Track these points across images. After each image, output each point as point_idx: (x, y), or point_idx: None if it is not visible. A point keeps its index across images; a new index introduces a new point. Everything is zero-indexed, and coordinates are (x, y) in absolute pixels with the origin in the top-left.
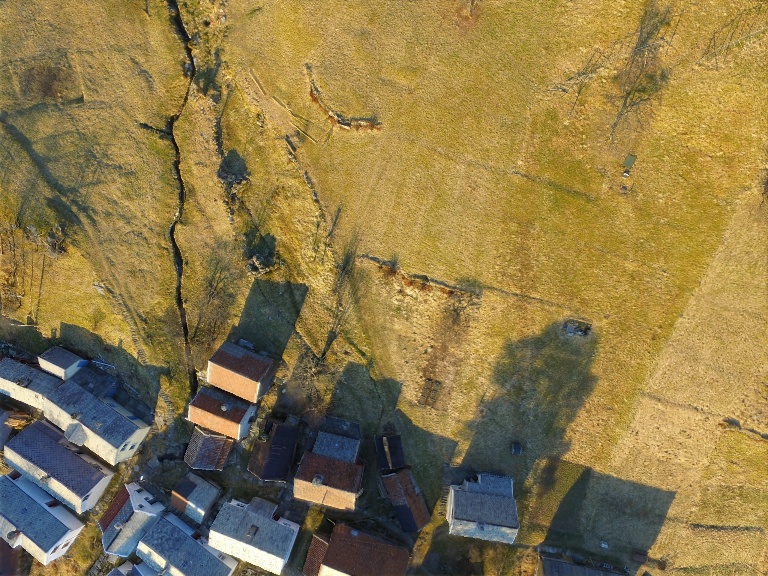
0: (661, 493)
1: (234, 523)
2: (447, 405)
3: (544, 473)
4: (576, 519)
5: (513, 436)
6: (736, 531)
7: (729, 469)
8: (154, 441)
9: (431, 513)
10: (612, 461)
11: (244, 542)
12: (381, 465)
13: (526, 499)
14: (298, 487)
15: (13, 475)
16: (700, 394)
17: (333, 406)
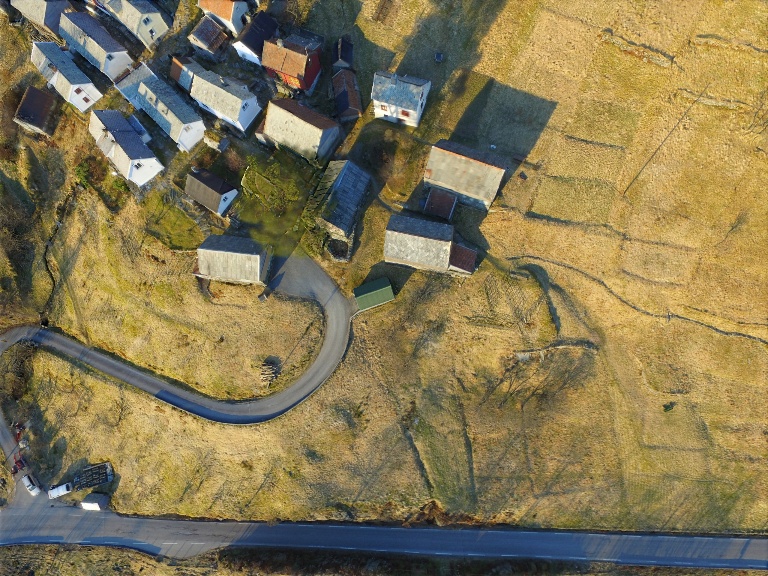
0: (545, 103)
1: (213, 78)
2: (393, 22)
3: (457, 83)
4: (475, 125)
5: (439, 50)
6: (601, 146)
7: (602, 84)
8: (169, 42)
9: (364, 110)
10: (511, 73)
11: (217, 85)
12: (333, 61)
13: (440, 105)
14: (266, 52)
15: (61, 48)
16: (586, 6)
17: (308, 22)
